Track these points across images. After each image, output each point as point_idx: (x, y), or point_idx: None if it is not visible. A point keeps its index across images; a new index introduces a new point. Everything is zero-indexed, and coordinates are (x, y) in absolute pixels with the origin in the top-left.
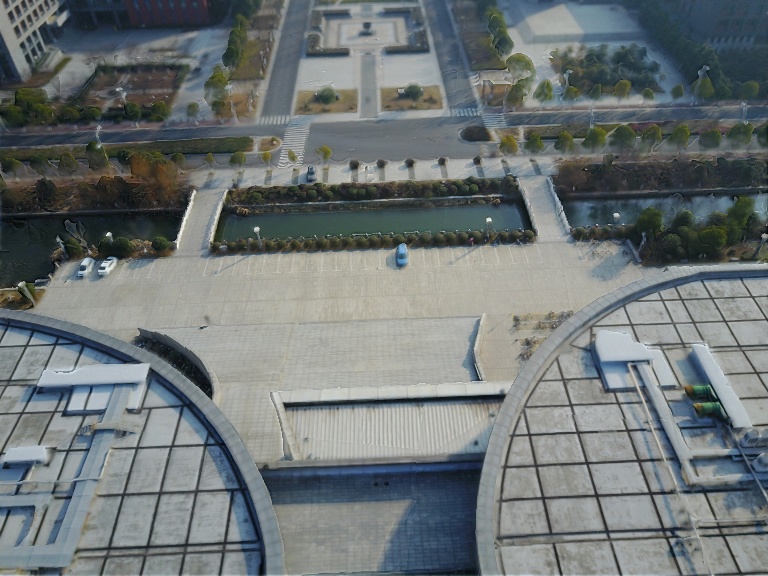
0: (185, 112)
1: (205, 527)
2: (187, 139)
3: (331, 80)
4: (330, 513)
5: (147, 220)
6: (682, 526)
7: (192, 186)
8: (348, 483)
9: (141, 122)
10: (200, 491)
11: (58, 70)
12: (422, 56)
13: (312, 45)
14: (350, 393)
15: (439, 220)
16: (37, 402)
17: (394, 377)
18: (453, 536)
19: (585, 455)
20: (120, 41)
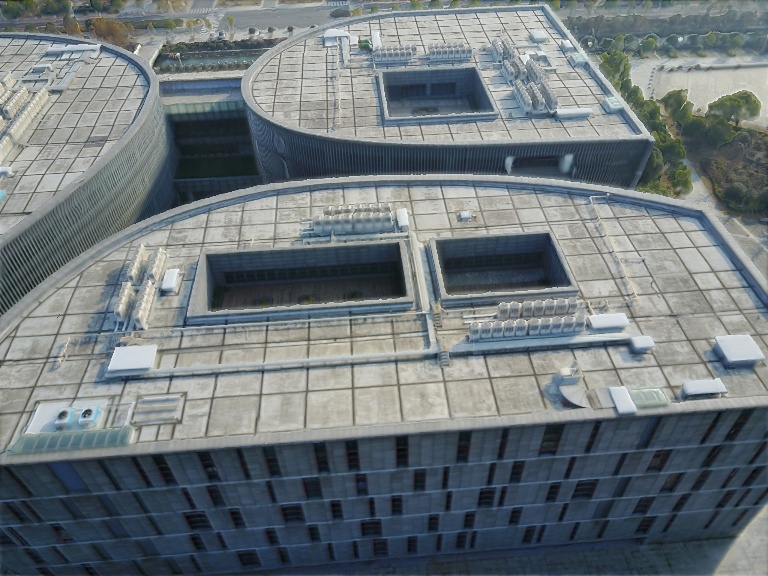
0: (135, 7)
1: (125, 83)
2: (136, 21)
3: None
4: (188, 98)
5: None
6: (335, 76)
7: (138, 43)
8: (199, 91)
9: (103, 14)
10: (124, 75)
11: None
12: None
13: None
14: None
15: None
16: (45, 58)
17: None
18: None
19: (303, 62)
20: None
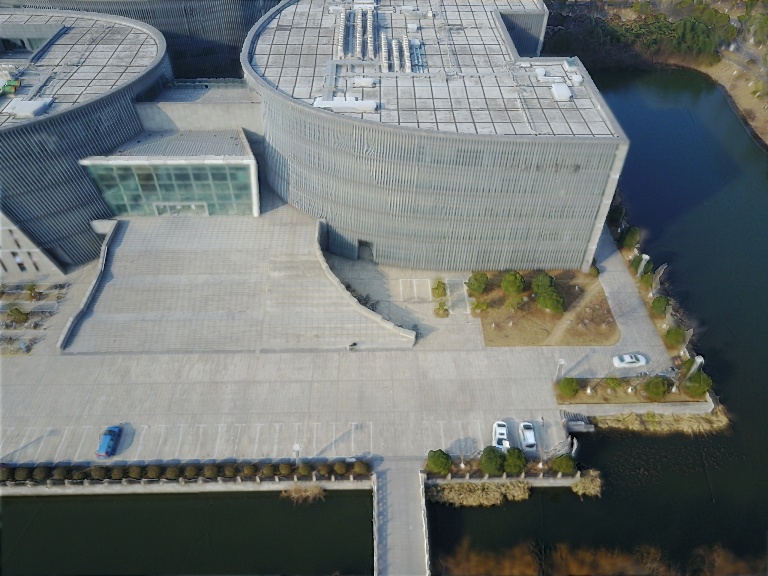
0: None
1: None
2: None
3: None
4: None
5: (503, 572)
6: None
7: None
8: None
9: None
10: None
11: None
12: None
13: None
14: (204, 158)
15: (9, 568)
16: None
17: (175, 263)
18: (171, 97)
19: None
20: None
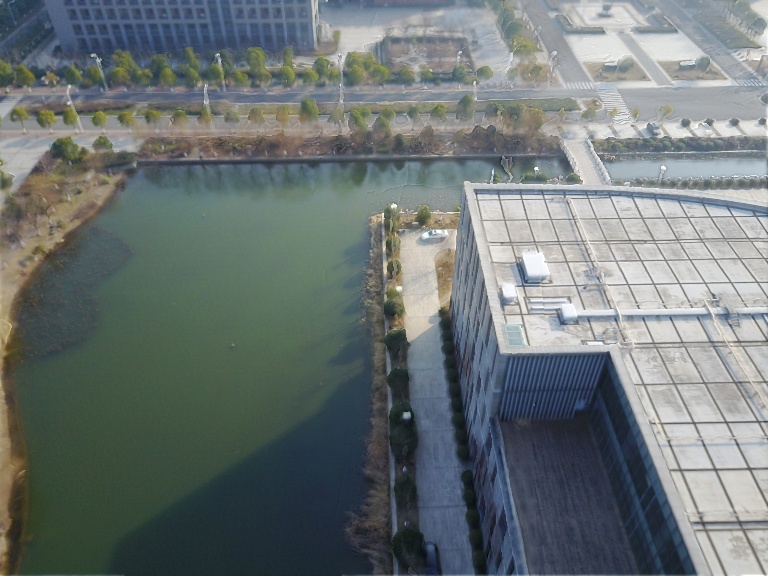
0: None
1: None
2: (516, 99)
3: (607, 53)
4: None
5: (526, 164)
6: None
7: (556, 136)
8: None
9: (460, 84)
10: None
11: (337, 40)
12: (673, 35)
13: (567, 24)
14: None
15: None
16: None
17: None
18: None
19: None
20: (371, 17)
